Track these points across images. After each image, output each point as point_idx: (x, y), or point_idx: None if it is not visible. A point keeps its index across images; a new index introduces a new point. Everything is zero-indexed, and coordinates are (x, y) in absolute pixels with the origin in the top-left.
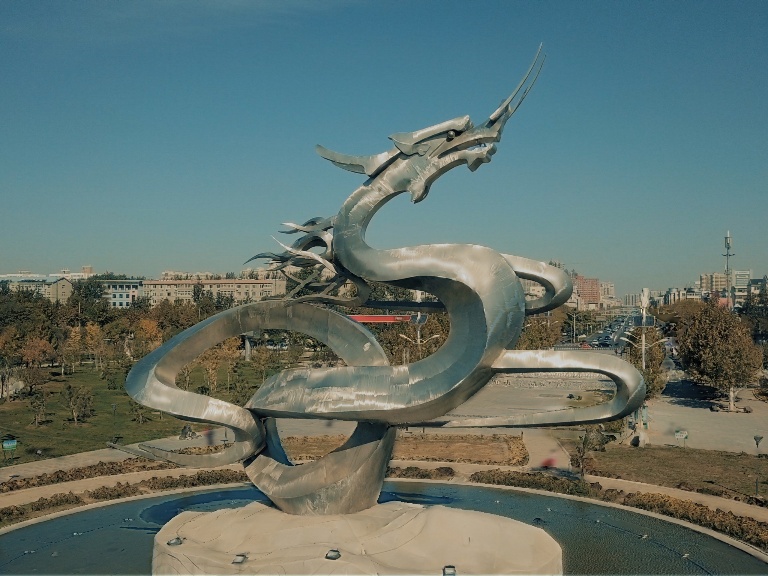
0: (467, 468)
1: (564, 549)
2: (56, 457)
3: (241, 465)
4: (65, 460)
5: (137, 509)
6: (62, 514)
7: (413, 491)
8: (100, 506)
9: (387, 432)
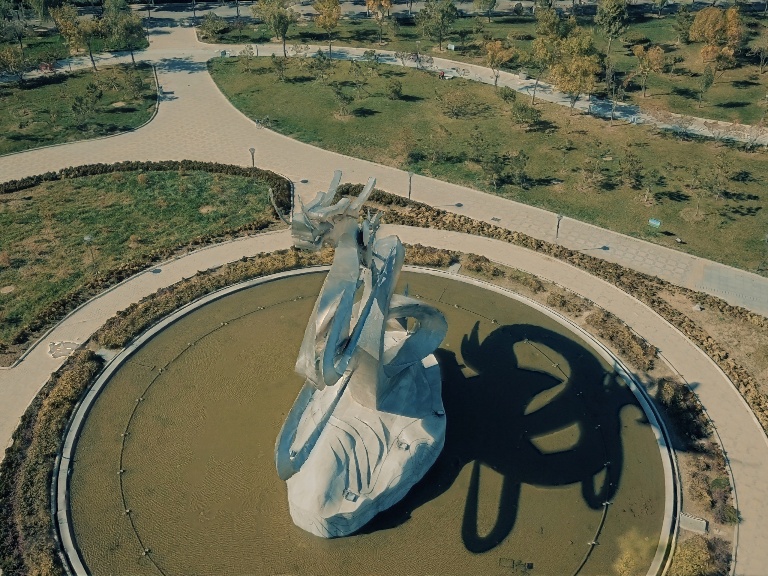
0: (766, 540)
1: (439, 568)
2: (682, 251)
3: (701, 357)
4: (675, 258)
5: (527, 320)
6: (497, 291)
7: (632, 482)
8: (524, 302)
9: (347, 372)
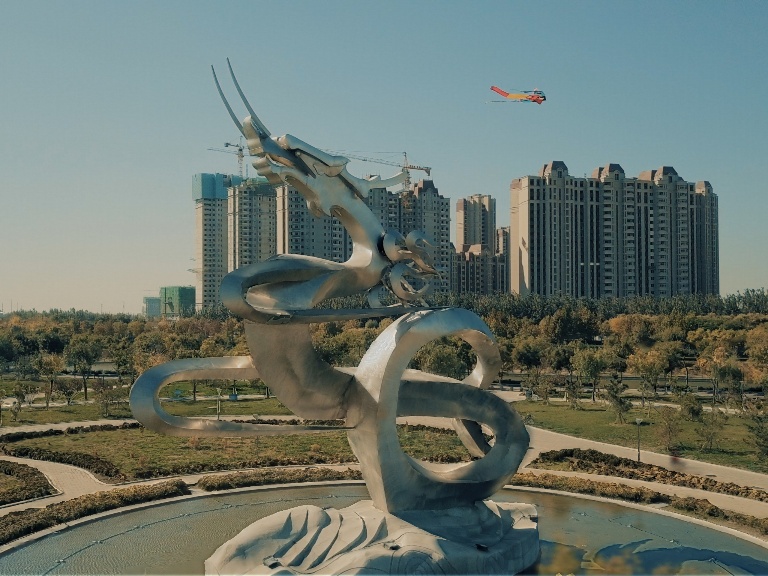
0: None
1: None
2: None
3: None
4: None
5: (731, 549)
6: (703, 523)
7: None
8: None
9: None
